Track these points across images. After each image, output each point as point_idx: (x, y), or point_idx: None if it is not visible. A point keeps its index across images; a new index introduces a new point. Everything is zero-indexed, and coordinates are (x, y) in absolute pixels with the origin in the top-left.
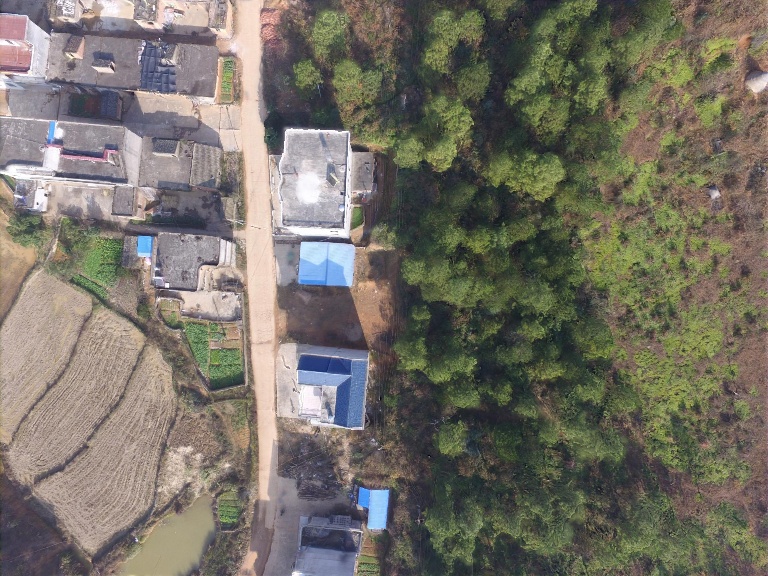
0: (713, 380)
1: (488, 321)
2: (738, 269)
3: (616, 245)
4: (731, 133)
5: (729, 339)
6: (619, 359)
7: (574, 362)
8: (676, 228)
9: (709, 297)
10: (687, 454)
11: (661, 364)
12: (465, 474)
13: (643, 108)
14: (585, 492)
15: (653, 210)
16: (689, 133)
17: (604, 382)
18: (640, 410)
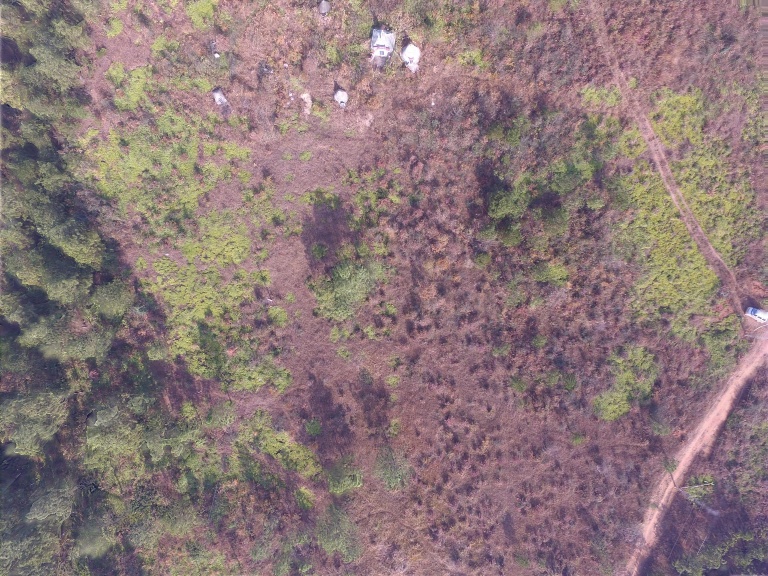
0: (242, 286)
1: (0, 234)
2: (259, 173)
3: (118, 152)
4: (225, 34)
5: (257, 245)
6: (138, 268)
7: (45, 264)
8: (185, 134)
9: (229, 202)
10: (215, 361)
11: (183, 271)
12: (0, 389)
13: (126, 13)
14: (110, 402)
15: (157, 116)
16: (181, 36)
17: (126, 292)
18: (161, 318)
